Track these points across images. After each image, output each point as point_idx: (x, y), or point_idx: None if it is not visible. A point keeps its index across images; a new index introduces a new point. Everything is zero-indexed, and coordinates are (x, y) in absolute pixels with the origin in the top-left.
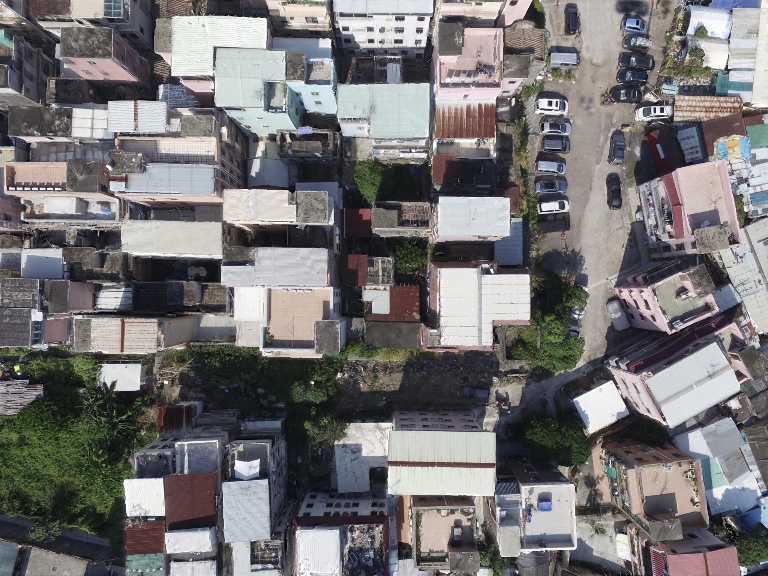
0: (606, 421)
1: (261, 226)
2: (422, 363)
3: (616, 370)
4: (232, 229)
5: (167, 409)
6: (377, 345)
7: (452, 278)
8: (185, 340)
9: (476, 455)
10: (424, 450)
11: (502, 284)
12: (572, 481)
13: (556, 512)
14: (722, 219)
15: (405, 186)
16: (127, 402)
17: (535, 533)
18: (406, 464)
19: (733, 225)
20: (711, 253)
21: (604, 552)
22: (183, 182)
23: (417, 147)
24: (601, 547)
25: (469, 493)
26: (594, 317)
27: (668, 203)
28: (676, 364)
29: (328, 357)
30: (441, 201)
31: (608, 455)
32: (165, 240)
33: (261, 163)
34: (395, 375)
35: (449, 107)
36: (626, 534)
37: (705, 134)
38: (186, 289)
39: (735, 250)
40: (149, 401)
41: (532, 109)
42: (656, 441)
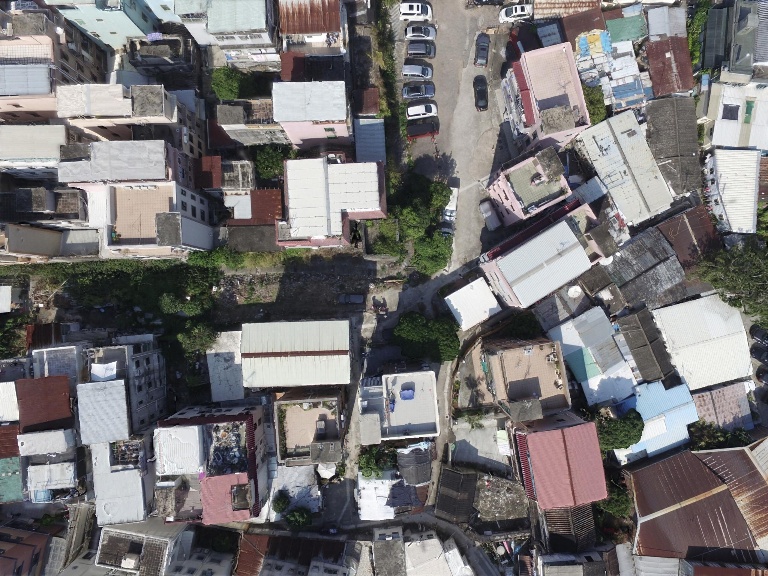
0: (479, 318)
1: (112, 132)
2: (299, 274)
3: (483, 265)
4: (87, 140)
5: (35, 326)
6: (240, 250)
7: (299, 169)
8: (46, 253)
9: (329, 343)
10: (277, 341)
11: (349, 173)
12: (453, 383)
13: (420, 401)
14: (572, 103)
15: (270, 96)
16: (1, 326)
17: (400, 423)
18: (259, 355)
19: (582, 108)
20: (581, 150)
21: (488, 452)
22: (19, 83)
23: (264, 45)
24: (485, 447)
25: (324, 382)
26: (468, 219)
27: (519, 91)
28: (526, 244)
29: (203, 272)
30: (275, 87)
31: (482, 351)
32: (7, 145)
33: (117, 75)
34: (271, 287)
35: (293, 3)
36: (504, 429)
37: (566, 31)
38: (34, 195)
39: (600, 143)
40: (25, 325)
41: (397, 16)
42: (526, 333)
